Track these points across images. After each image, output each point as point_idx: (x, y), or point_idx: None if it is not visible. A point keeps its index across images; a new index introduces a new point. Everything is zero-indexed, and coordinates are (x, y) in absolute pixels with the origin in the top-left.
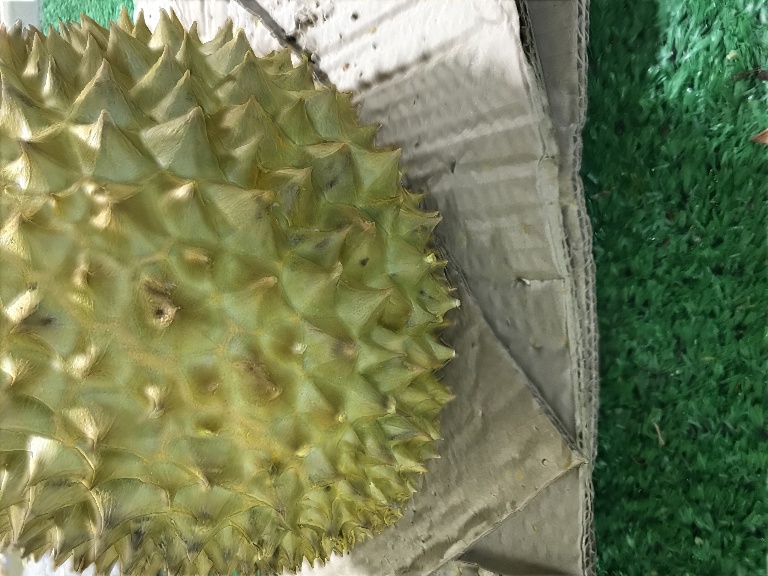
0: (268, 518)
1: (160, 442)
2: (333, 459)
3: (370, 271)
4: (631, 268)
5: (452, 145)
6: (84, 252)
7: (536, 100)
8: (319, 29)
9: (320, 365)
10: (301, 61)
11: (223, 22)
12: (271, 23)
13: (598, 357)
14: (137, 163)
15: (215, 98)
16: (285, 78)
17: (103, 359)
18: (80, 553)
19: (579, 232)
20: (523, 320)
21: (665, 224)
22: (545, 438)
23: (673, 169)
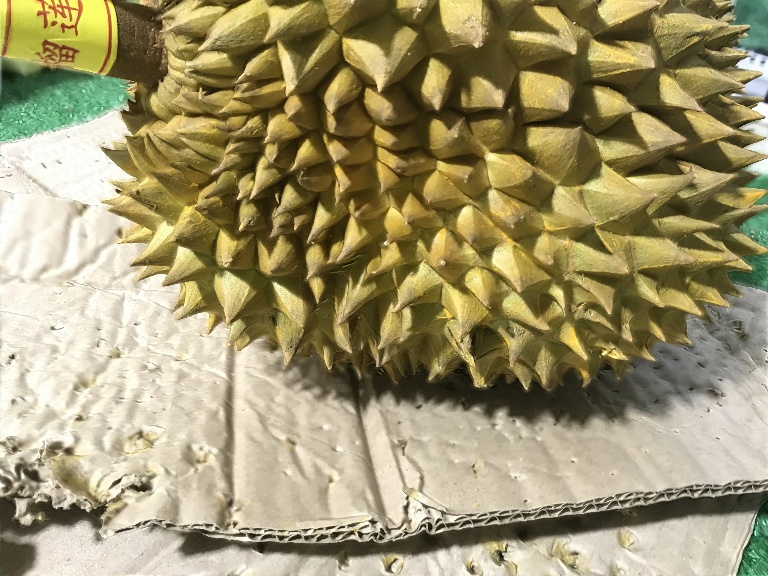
0: None
1: None
2: None
3: None
4: None
5: None
6: None
7: None
8: None
9: None
10: None
11: (112, 232)
12: None
13: None
14: None
15: None
16: None
17: None
18: None
19: None
20: None
21: None
22: None
23: None
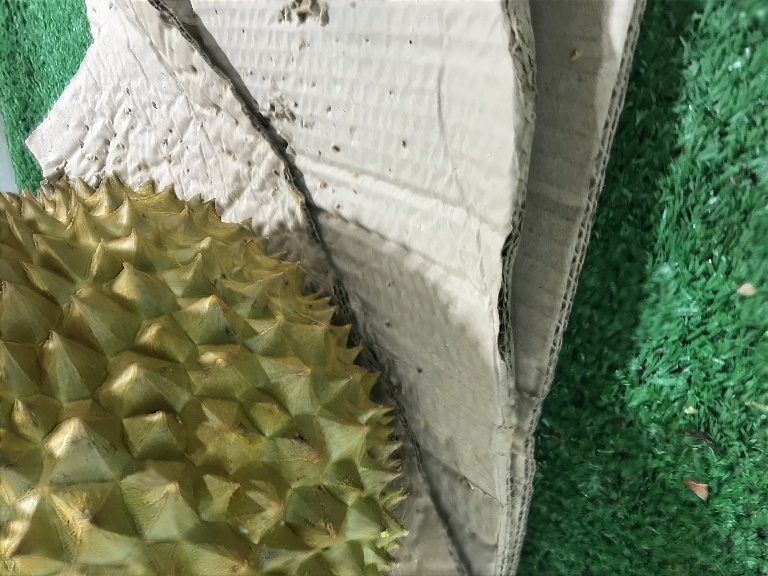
0: None
1: None
2: None
3: None
4: (563, 503)
5: (421, 357)
6: None
7: (503, 388)
8: (296, 130)
9: None
10: (275, 153)
11: (187, 64)
12: (243, 89)
13: (522, 546)
14: (116, 548)
15: (186, 379)
16: (257, 340)
17: None
18: None
19: (523, 474)
20: (463, 510)
21: (599, 489)
22: None
23: (616, 455)
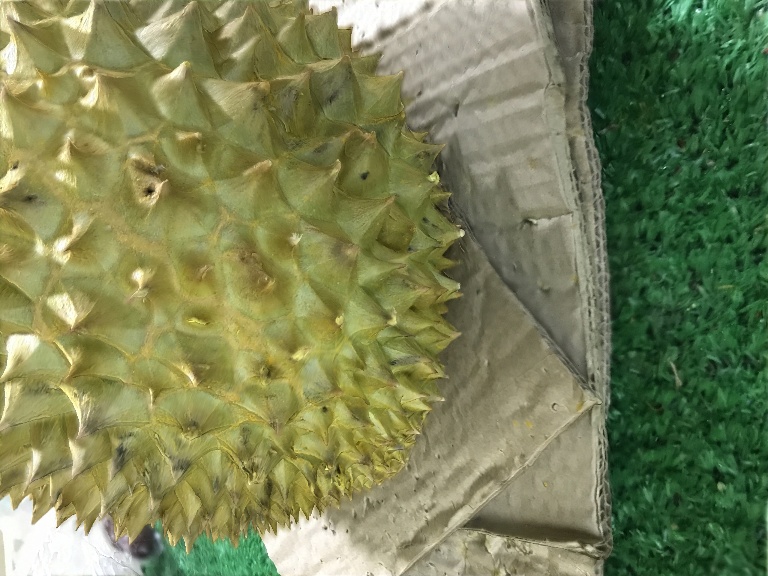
0: (259, 439)
1: (143, 333)
2: (329, 373)
3: (370, 187)
4: (642, 201)
5: (455, 87)
6: (69, 132)
7: (541, 26)
8: None
9: (316, 266)
10: None
11: None
12: None
13: (609, 299)
14: (129, 51)
15: (213, 19)
16: (285, 6)
17: (84, 236)
18: (58, 486)
19: (587, 164)
20: (530, 262)
21: (676, 152)
22: (555, 380)
23: (683, 94)
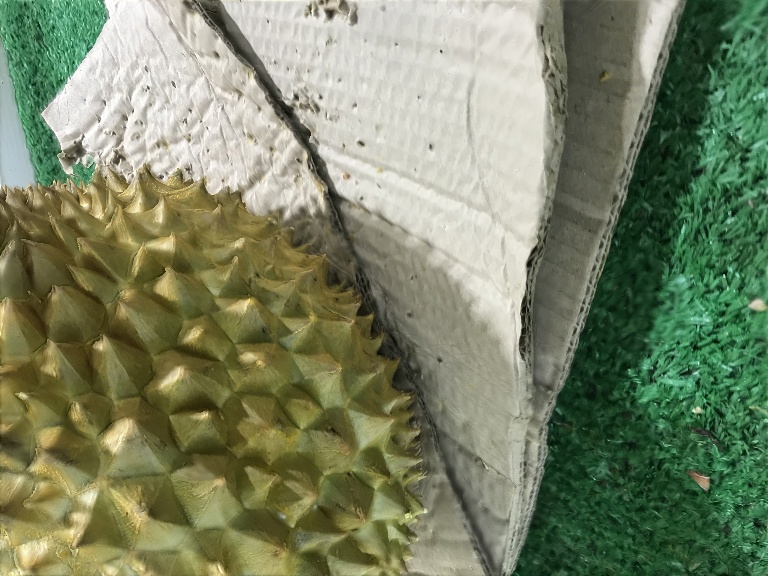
0: None
1: None
2: None
3: None
4: None
5: (442, 349)
6: None
7: (522, 384)
8: (320, 121)
9: None
10: (298, 142)
11: (209, 50)
12: (266, 77)
13: (531, 520)
14: (170, 536)
15: (225, 376)
16: (291, 338)
17: None
18: None
19: (536, 458)
20: (477, 487)
21: (607, 474)
22: None
23: (625, 445)
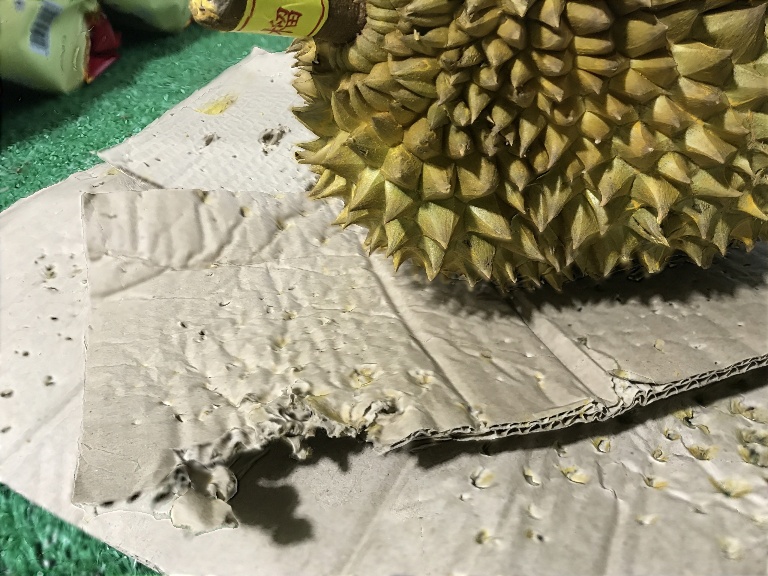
0: None
1: None
2: None
3: None
4: None
5: None
6: None
7: None
8: None
9: None
10: None
11: (236, 213)
12: None
13: None
14: None
15: None
16: None
17: None
18: None
19: None
20: None
21: None
22: None
23: None
